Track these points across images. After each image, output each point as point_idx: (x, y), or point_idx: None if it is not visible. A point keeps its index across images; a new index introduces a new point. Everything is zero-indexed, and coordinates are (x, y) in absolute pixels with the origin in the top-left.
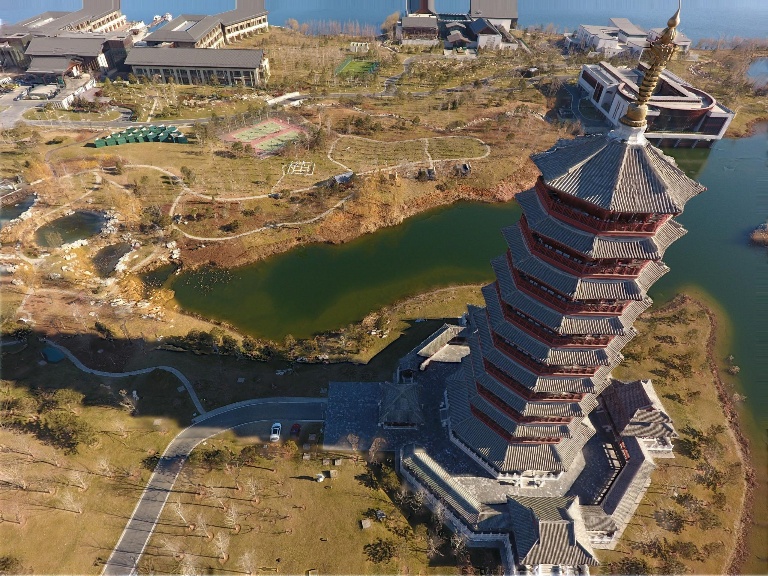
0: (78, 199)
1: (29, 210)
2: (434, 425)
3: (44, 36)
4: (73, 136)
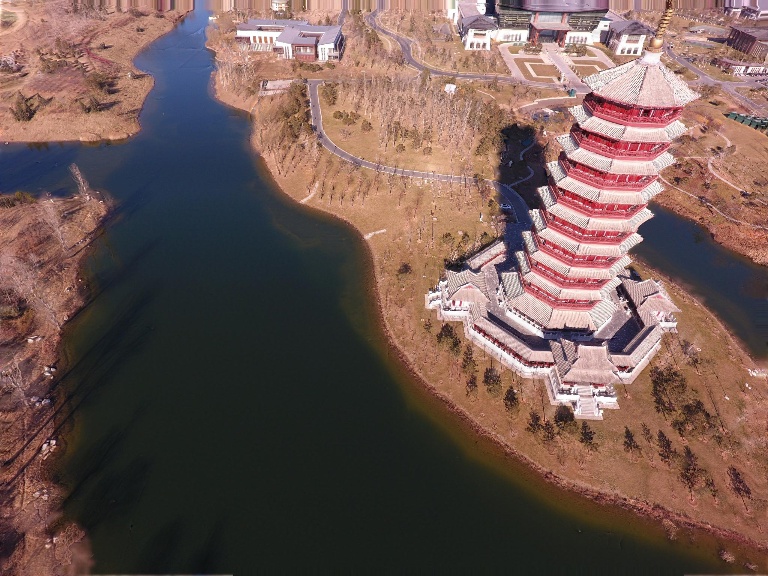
0: None
1: None
2: None
3: None
4: (731, 107)
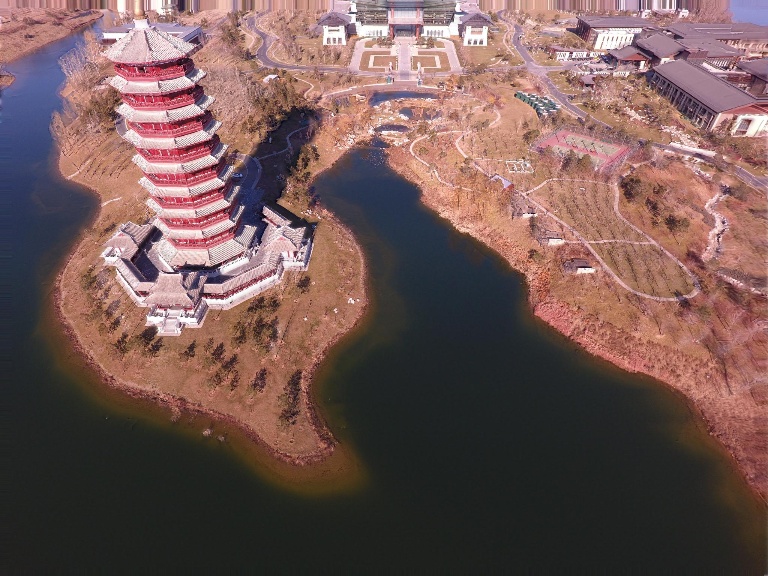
0: (450, 108)
1: (434, 99)
2: None
3: (682, 38)
4: None
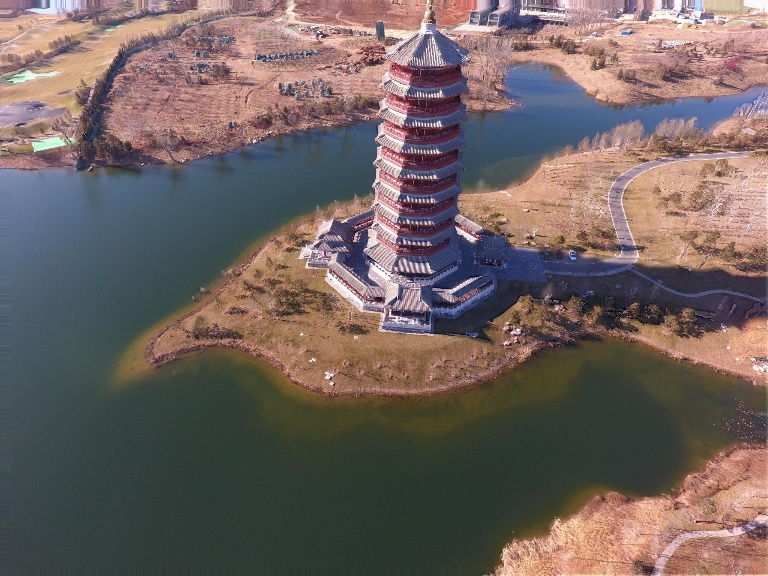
0: None
1: None
2: (466, 255)
3: None
4: None
